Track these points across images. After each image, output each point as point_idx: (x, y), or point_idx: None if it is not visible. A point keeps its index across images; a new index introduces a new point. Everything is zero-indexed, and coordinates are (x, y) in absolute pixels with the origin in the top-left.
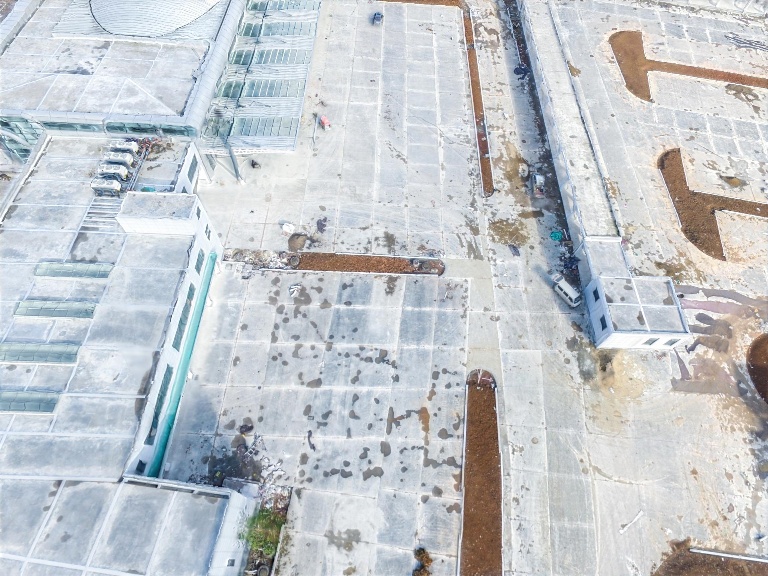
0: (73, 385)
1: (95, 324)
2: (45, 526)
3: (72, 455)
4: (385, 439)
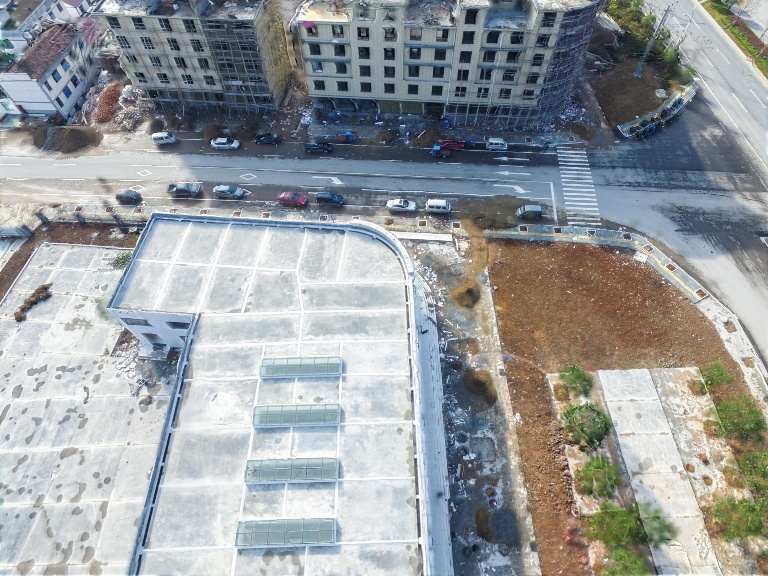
0: (253, 386)
1: (246, 456)
2: (249, 285)
3: (240, 330)
4: (14, 400)
